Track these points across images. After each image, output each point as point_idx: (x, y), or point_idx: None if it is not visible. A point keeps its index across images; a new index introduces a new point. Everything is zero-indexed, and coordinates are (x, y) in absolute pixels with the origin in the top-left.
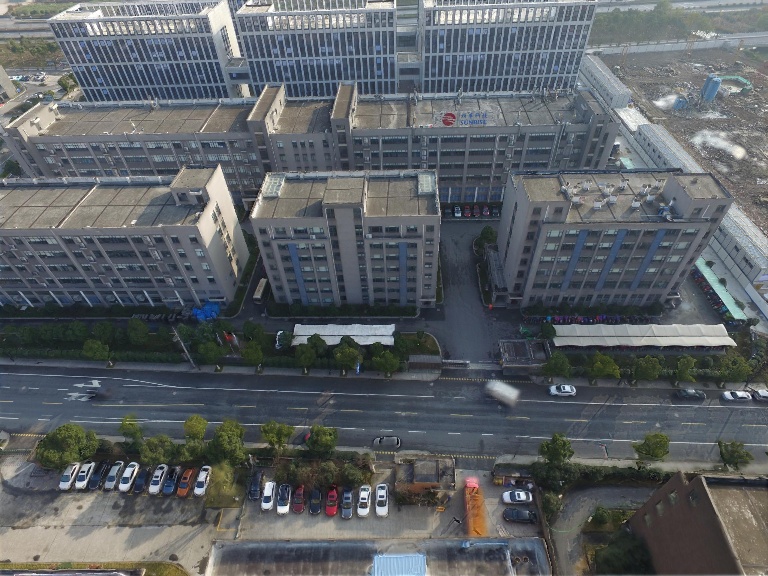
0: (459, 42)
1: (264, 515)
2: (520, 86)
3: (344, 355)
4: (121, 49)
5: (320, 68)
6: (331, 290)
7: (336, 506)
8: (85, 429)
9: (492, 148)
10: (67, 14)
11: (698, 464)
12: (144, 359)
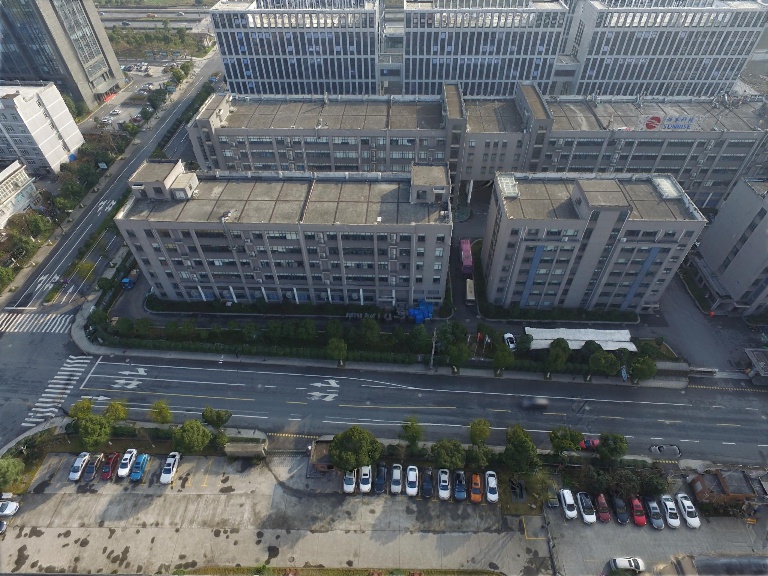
0: (625, 45)
1: (570, 524)
2: (675, 91)
3: (606, 361)
4: (278, 42)
5: (476, 67)
6: (556, 293)
7: (644, 516)
8: (342, 430)
9: (686, 153)
10: (223, 5)
11: None
12: (378, 359)
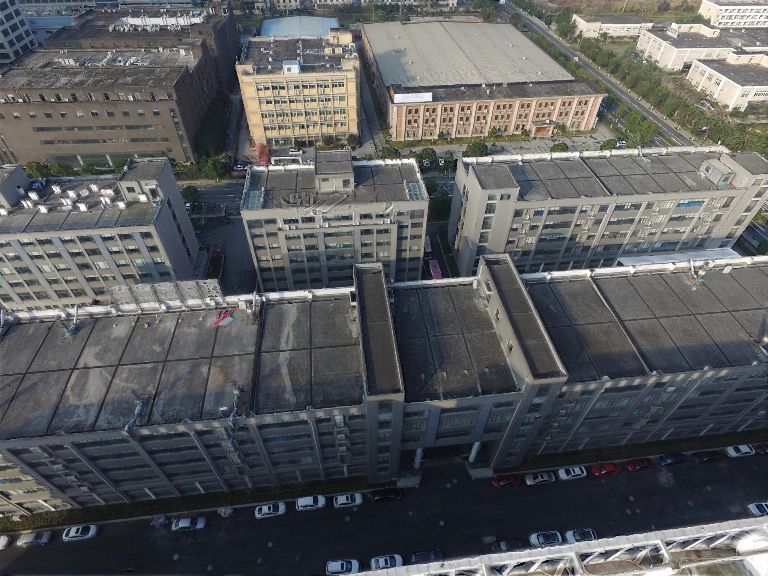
0: None
1: None
2: None
3: None
4: None
5: None
6: None
7: None
8: None
9: None
10: None
11: None
12: None
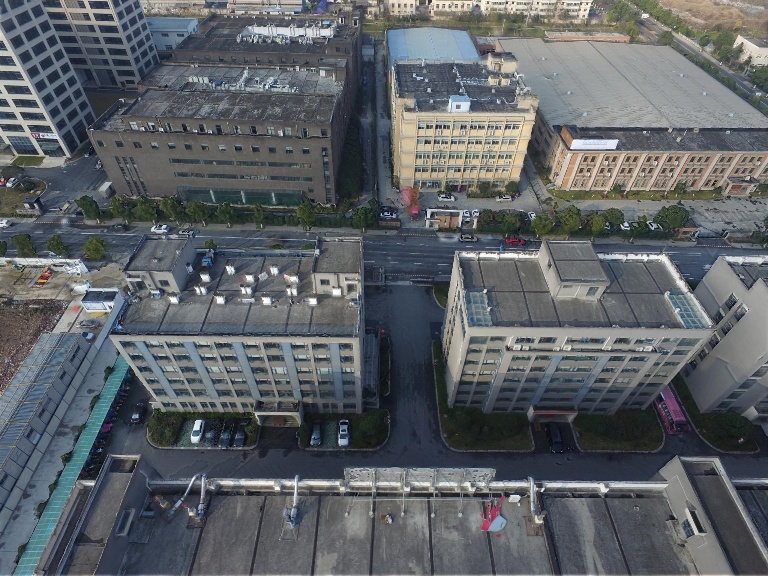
0: None
1: None
2: None
3: None
4: None
5: None
6: None
7: None
8: (683, 249)
9: None
10: None
11: (273, 230)
12: None
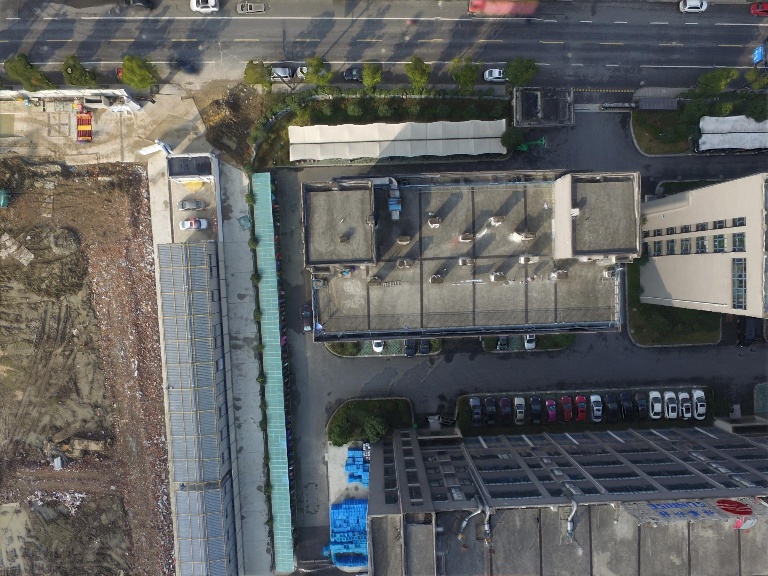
0: None
1: None
2: None
3: None
4: None
5: None
6: None
7: None
8: None
9: None
10: None
11: None
12: None
